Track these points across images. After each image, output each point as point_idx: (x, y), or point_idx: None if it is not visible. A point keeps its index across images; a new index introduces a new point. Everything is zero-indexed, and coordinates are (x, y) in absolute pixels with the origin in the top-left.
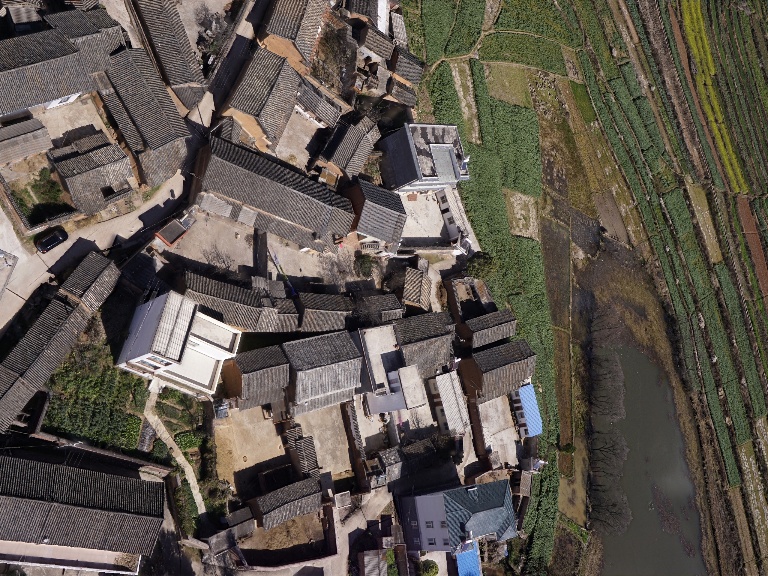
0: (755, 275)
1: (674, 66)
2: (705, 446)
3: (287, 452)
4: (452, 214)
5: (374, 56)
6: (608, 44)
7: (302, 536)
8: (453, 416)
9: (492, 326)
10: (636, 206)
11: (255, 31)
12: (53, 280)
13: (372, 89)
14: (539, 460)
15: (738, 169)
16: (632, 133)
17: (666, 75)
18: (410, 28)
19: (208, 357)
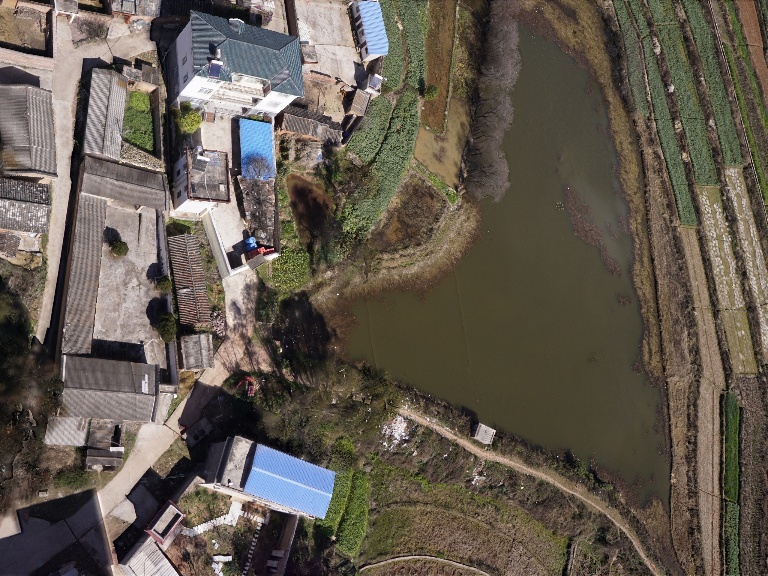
0: (739, 20)
1: None
2: (650, 175)
3: None
4: None
5: None
6: None
7: (13, 36)
8: None
9: None
10: None
11: None
12: None
13: None
14: None
15: None
16: None
17: None
18: None
19: None
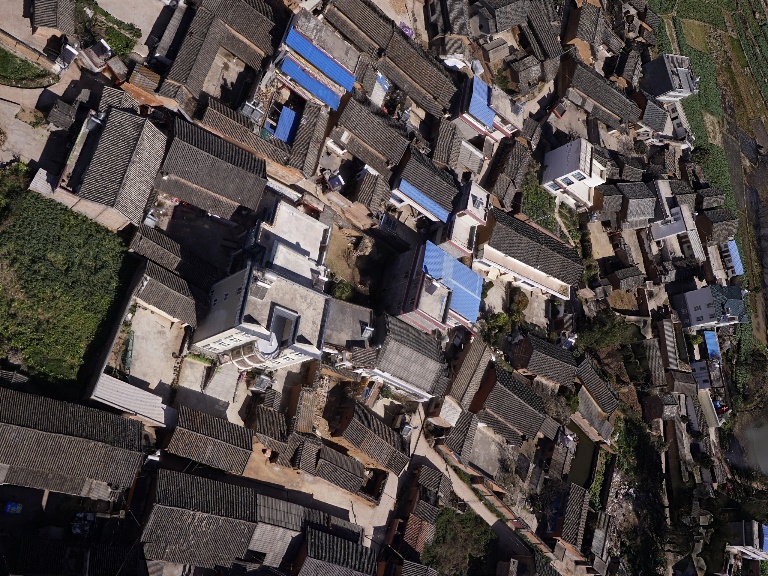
0: None
1: None
2: None
3: (616, 254)
4: (681, 120)
5: (632, 10)
6: (752, 9)
7: (628, 305)
8: (697, 249)
9: (712, 196)
10: None
11: None
12: None
13: (629, 33)
14: None
15: None
16: None
17: None
18: None
19: (585, 185)
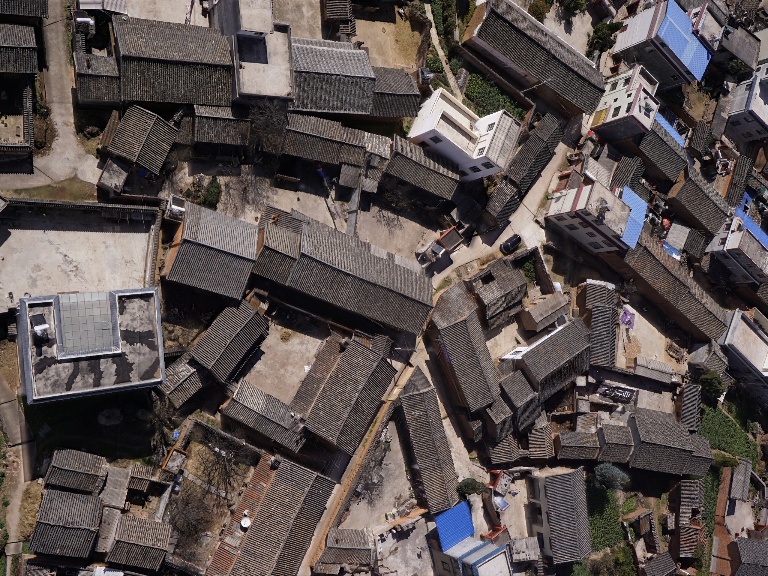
0: None
1: None
2: None
3: None
4: None
5: None
6: None
7: None
8: None
9: None
10: None
11: None
12: None
13: None
14: None
15: None
16: None
17: None
18: None
19: None
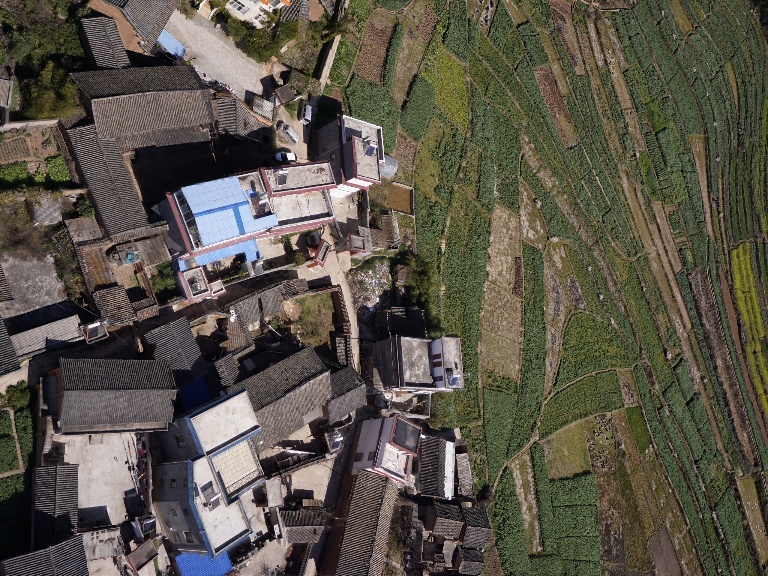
0: None
1: (725, 343)
2: None
3: None
4: None
5: None
6: (662, 346)
7: None
8: None
9: None
10: (689, 530)
11: (317, 567)
12: None
13: None
14: None
15: None
16: (685, 444)
17: (717, 356)
18: (473, 448)
19: None
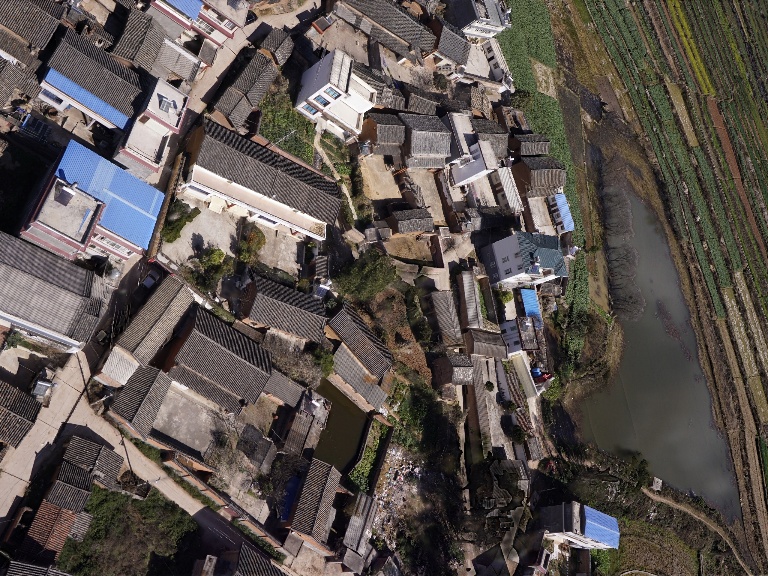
0: (726, 160)
1: None
2: (695, 284)
3: (403, 197)
4: (497, 60)
5: None
6: None
7: (418, 255)
8: (512, 198)
9: (533, 142)
10: (627, 92)
11: None
12: (251, 45)
13: None
14: (574, 246)
15: (706, 76)
16: (620, 36)
17: None
18: None
19: (353, 110)
